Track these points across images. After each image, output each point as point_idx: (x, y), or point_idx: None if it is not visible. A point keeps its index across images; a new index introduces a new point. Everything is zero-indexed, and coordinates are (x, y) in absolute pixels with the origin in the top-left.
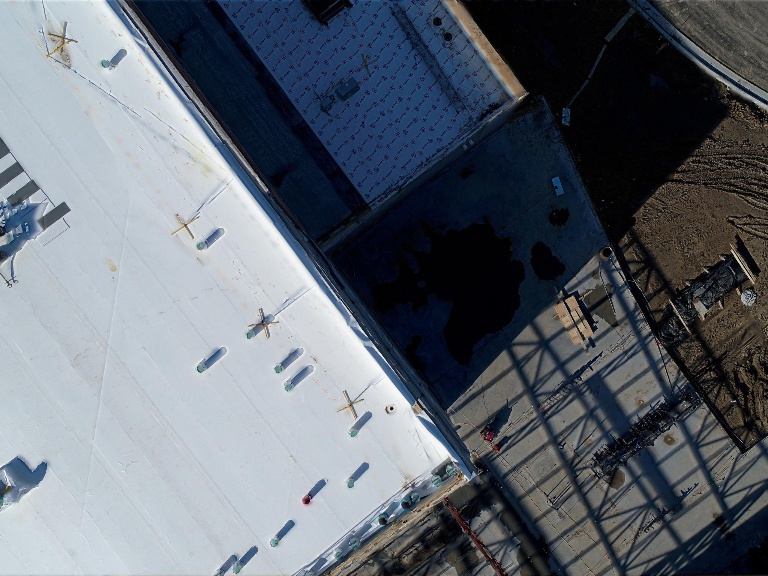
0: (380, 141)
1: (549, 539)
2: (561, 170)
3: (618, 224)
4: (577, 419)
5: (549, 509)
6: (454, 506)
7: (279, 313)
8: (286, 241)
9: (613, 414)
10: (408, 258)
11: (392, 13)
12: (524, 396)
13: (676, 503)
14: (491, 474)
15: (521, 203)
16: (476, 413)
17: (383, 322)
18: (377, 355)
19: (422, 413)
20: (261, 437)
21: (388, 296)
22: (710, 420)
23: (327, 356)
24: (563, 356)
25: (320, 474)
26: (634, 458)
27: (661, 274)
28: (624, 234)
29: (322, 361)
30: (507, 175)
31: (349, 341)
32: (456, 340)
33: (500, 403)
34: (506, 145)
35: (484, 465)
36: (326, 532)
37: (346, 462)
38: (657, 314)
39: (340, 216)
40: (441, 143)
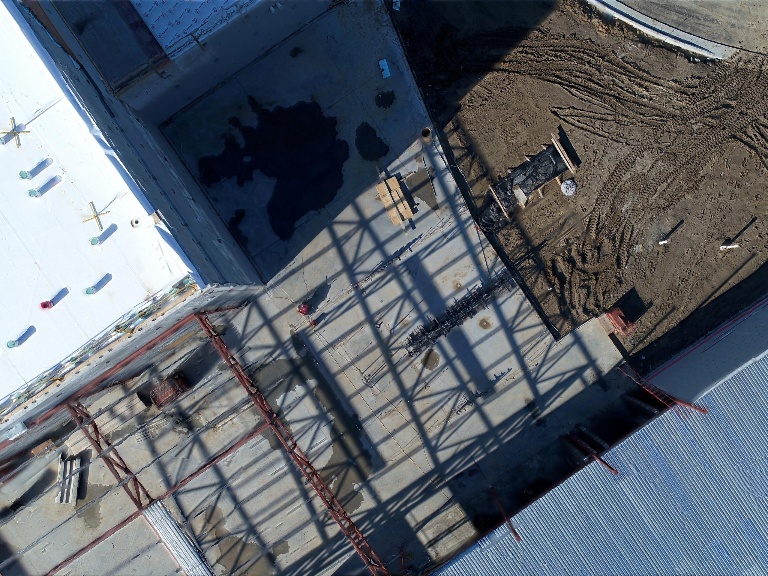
0: None
1: (362, 416)
2: (388, 53)
3: (444, 110)
4: (395, 299)
5: (363, 387)
6: (270, 379)
7: (30, 123)
8: (32, 47)
9: (430, 296)
10: (235, 132)
11: None
12: (343, 274)
13: (489, 387)
14: (308, 349)
15: (348, 84)
16: (295, 288)
17: (208, 194)
18: (118, 164)
19: (160, 223)
20: (7, 243)
21: (213, 169)
22: (525, 306)
23: (75, 167)
24: (383, 236)
25: (63, 282)
26: (449, 340)
27: (484, 161)
28: (449, 120)
29: (70, 172)
30: (335, 55)
31: (97, 153)
32: (279, 215)
33: (319, 279)
34: (335, 26)
35: (301, 340)
36: (66, 339)
37: (89, 272)
38: (479, 200)
39: None
40: None
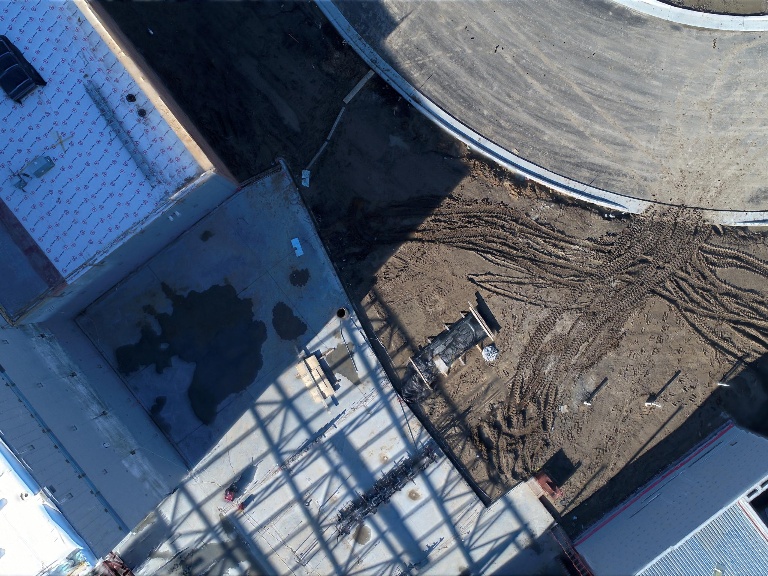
0: (76, 216)
1: None
2: (300, 231)
3: (360, 283)
4: (322, 476)
5: (296, 565)
6: (202, 564)
7: None
8: None
9: (358, 471)
10: (151, 320)
11: (86, 90)
12: (269, 454)
13: (422, 557)
14: (238, 532)
15: (261, 264)
16: (222, 472)
17: (128, 383)
18: (1, 445)
19: (47, 501)
20: None
21: (132, 358)
22: (454, 475)
23: None
24: (307, 414)
25: None
26: (379, 514)
27: (404, 332)
28: (366, 293)
29: None
30: (247, 237)
31: None
32: (200, 400)
33: (245, 462)
34: (245, 207)
35: (231, 523)
36: None
37: None
38: (401, 371)
39: (37, 291)
40: (137, 217)
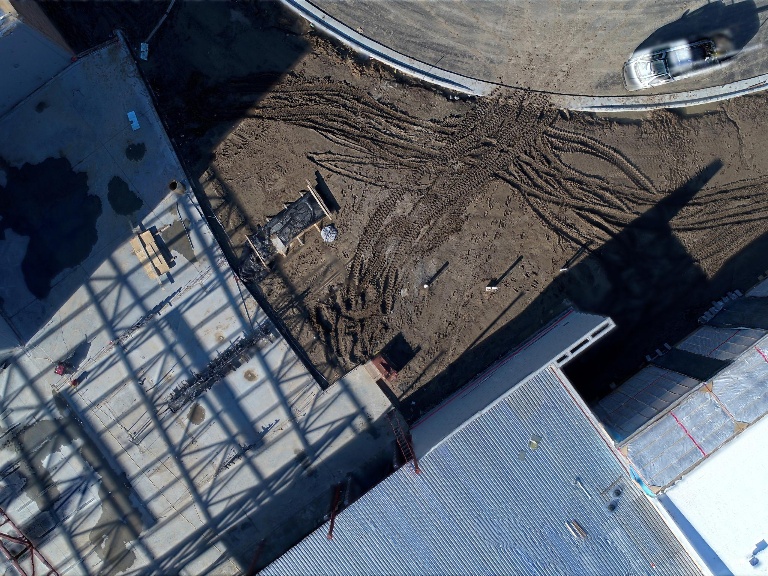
0: None
1: (130, 474)
2: (137, 105)
3: (198, 160)
4: (156, 354)
5: (130, 444)
6: (34, 441)
7: None
8: None
9: (193, 350)
10: None
11: None
12: (103, 331)
13: (257, 439)
14: (71, 409)
15: (97, 138)
16: (55, 348)
17: None
18: None
19: None
20: None
21: None
22: (290, 356)
23: None
24: (142, 291)
25: None
26: (214, 394)
27: (243, 210)
28: (204, 170)
29: None
30: (83, 109)
31: None
32: (34, 275)
33: (79, 338)
34: (81, 79)
35: (64, 400)
36: None
37: None
38: (239, 250)
39: None
40: None
